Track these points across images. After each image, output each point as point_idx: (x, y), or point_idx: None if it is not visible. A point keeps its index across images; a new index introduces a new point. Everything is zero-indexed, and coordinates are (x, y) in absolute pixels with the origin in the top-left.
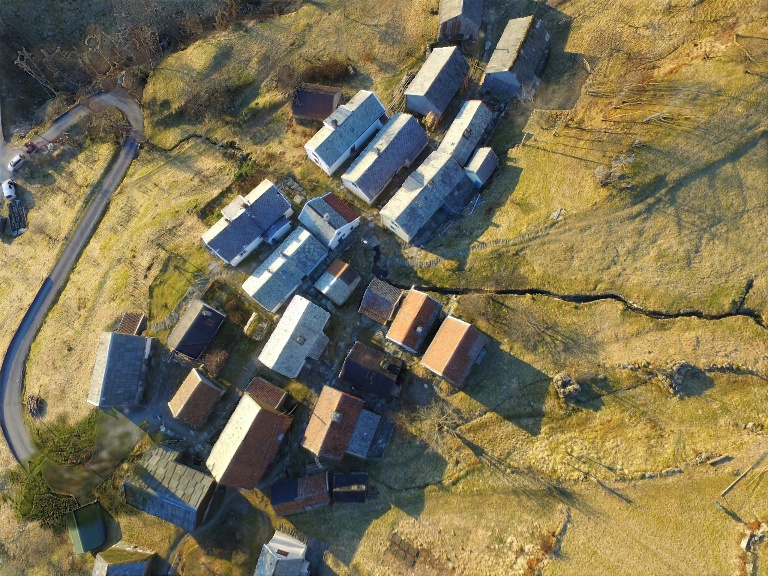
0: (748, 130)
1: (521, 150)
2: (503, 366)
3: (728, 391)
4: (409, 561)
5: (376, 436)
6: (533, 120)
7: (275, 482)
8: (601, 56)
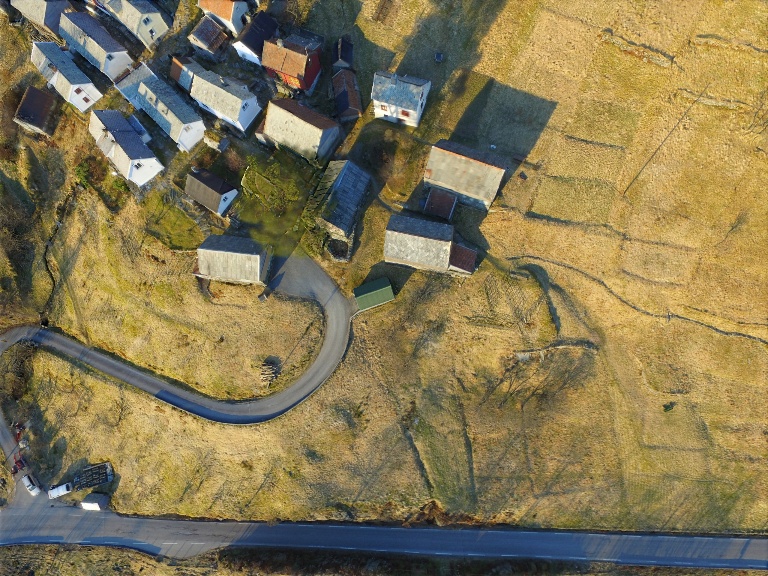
0: None
1: None
2: None
3: None
4: (388, 4)
5: None
6: None
7: (341, 124)
8: None
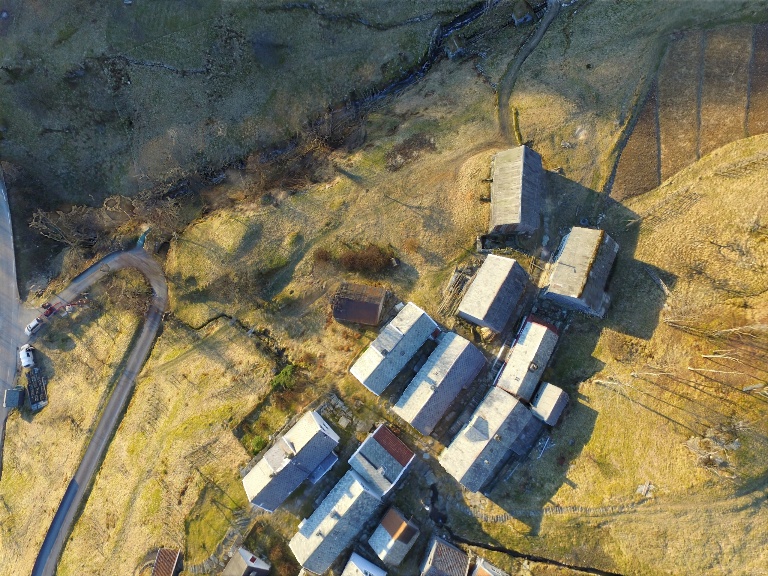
0: None
1: (594, 389)
2: None
3: None
4: None
5: None
6: (604, 343)
7: None
8: (679, 275)
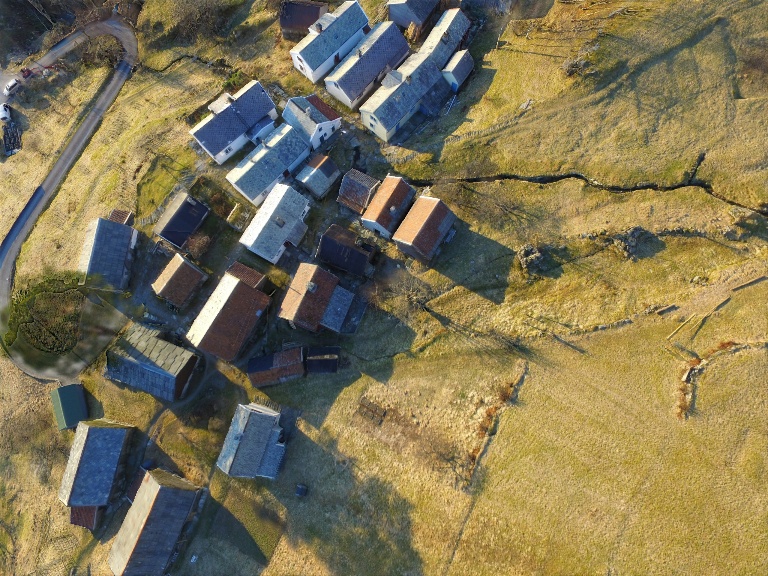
0: (704, 18)
1: (496, 53)
2: (471, 245)
3: (678, 252)
4: (376, 420)
5: (350, 314)
6: (509, 29)
7: None
8: None
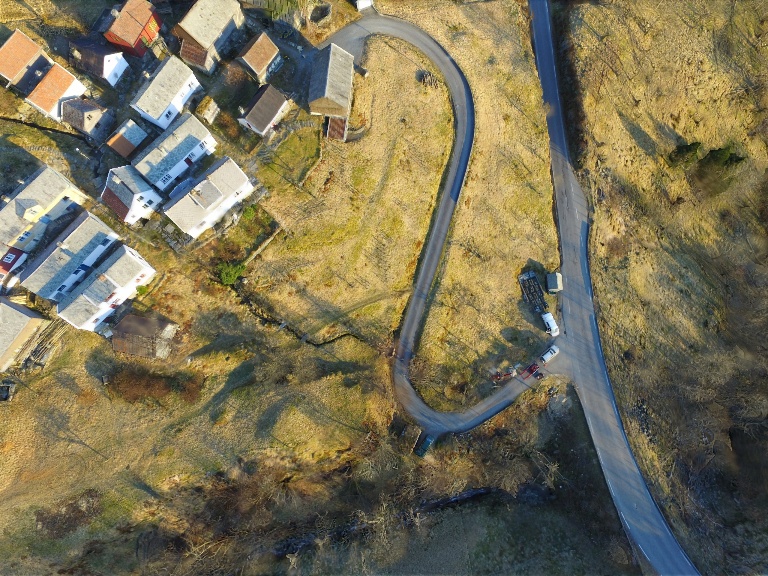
0: None
1: None
2: None
3: None
4: None
5: None
6: None
7: None
8: None
